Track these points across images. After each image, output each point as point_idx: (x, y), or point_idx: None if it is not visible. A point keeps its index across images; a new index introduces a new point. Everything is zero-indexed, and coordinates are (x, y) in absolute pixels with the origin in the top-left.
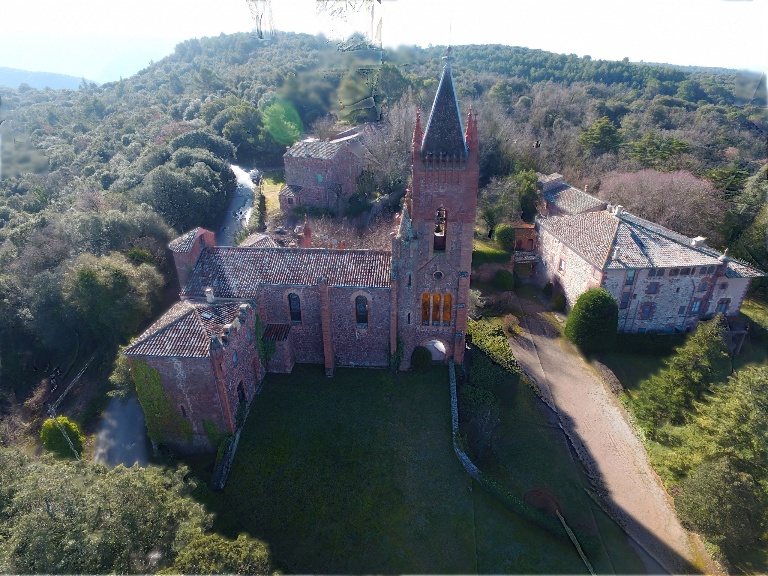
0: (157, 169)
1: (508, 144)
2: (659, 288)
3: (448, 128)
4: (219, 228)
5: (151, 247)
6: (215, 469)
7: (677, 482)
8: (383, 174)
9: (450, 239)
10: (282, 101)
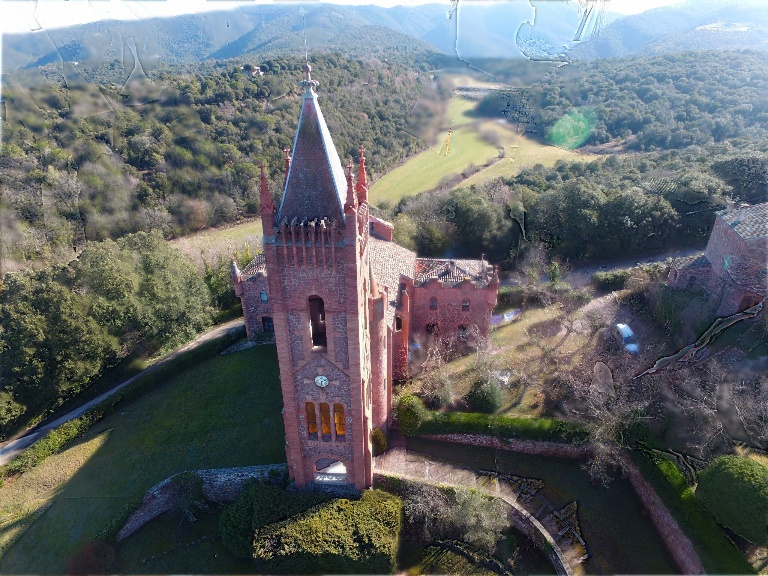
0: (574, 179)
1: None
2: None
3: None
4: (600, 264)
5: (450, 233)
6: None
7: None
8: None
9: None
10: None
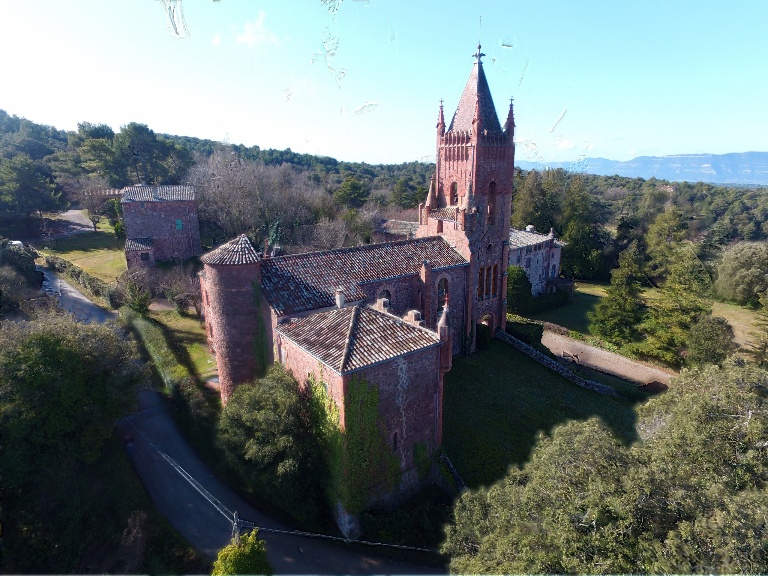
0: None
1: (419, 160)
2: (530, 262)
3: (489, 112)
4: None
5: None
6: (459, 494)
7: (670, 353)
8: (254, 214)
9: (498, 211)
10: (308, 86)
